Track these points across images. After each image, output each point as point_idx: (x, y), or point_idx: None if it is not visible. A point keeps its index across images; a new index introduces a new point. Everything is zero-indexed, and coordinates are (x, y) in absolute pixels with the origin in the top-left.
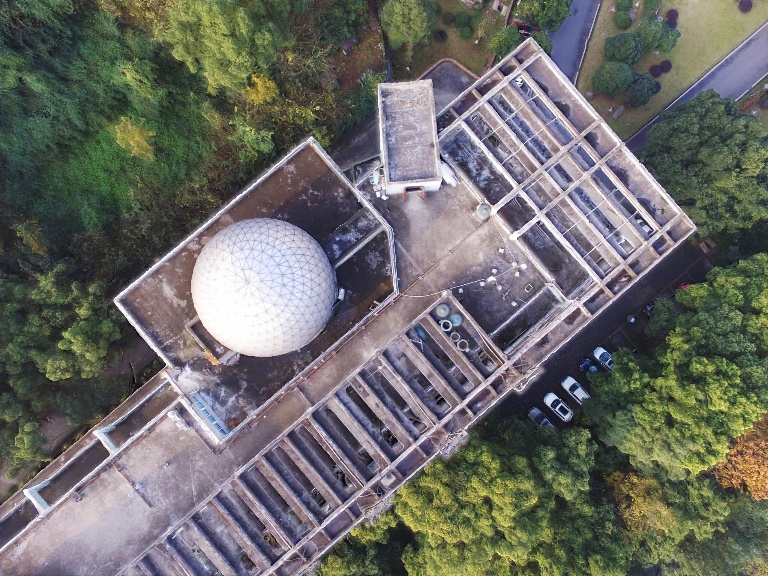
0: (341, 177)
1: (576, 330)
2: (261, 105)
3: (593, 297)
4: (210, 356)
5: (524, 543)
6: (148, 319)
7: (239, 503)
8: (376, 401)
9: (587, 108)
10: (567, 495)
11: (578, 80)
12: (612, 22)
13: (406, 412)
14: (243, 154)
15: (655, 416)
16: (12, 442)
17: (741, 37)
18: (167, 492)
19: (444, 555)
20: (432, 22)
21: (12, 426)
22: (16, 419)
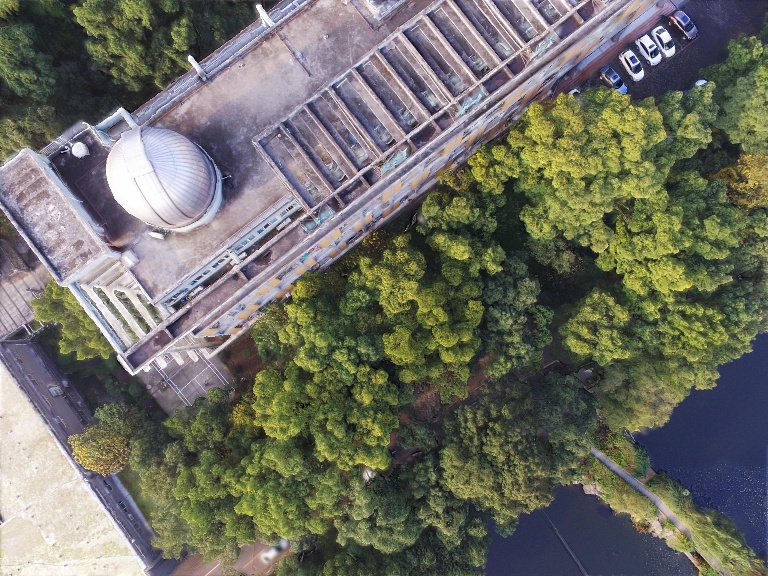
0: None
1: None
2: None
3: None
4: None
5: None
6: None
7: None
8: None
9: None
10: (695, 133)
11: None
12: None
13: None
14: None
15: None
16: (166, 43)
17: None
18: (326, 63)
19: (571, 188)
20: None
21: (165, 31)
22: (172, 16)
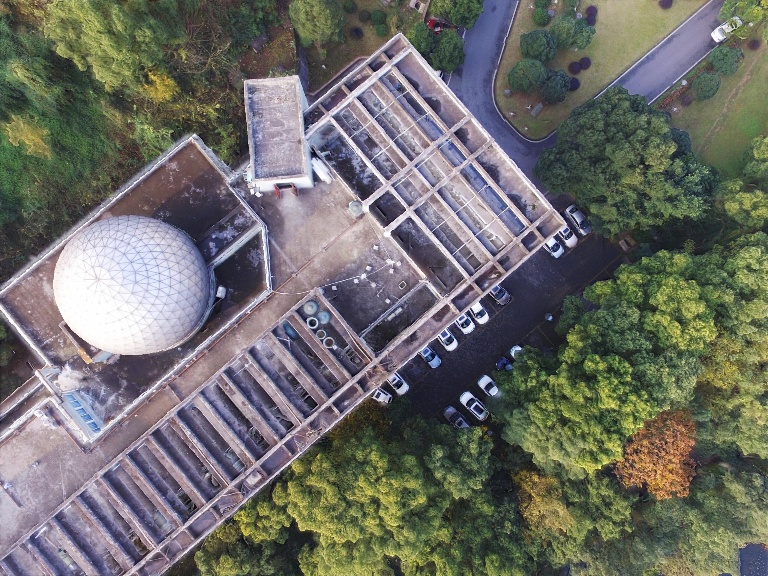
0: (223, 174)
1: (444, 327)
2: (161, 103)
3: (463, 294)
4: (84, 355)
5: (412, 543)
6: (28, 318)
7: (108, 502)
8: (242, 399)
9: (457, 104)
10: (456, 494)
11: (496, 77)
12: (531, 19)
13: (274, 410)
14: (146, 153)
15: (548, 414)
16: None
17: (662, 33)
18: (37, 491)
19: (332, 555)
20: (341, 20)
21: None
22: None
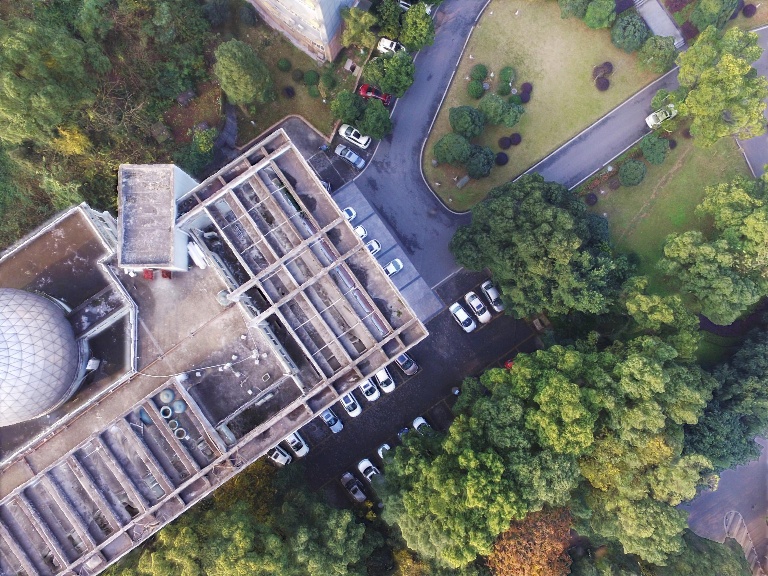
0: None
1: (296, 428)
2: (71, 156)
3: (320, 395)
4: None
5: None
6: None
7: None
8: (89, 482)
9: (332, 204)
10: None
11: (425, 146)
12: (465, 90)
13: (122, 495)
14: (56, 202)
15: (420, 506)
16: None
17: (597, 115)
18: None
19: None
20: (266, 82)
21: None
22: None
